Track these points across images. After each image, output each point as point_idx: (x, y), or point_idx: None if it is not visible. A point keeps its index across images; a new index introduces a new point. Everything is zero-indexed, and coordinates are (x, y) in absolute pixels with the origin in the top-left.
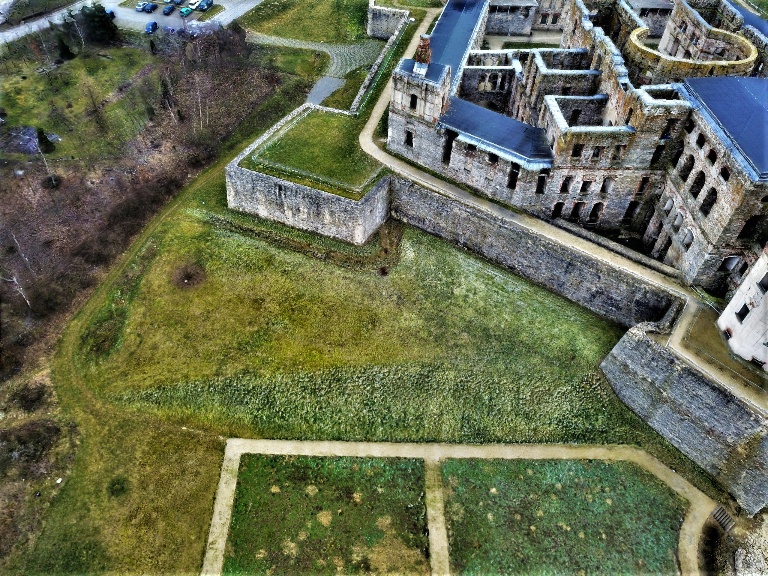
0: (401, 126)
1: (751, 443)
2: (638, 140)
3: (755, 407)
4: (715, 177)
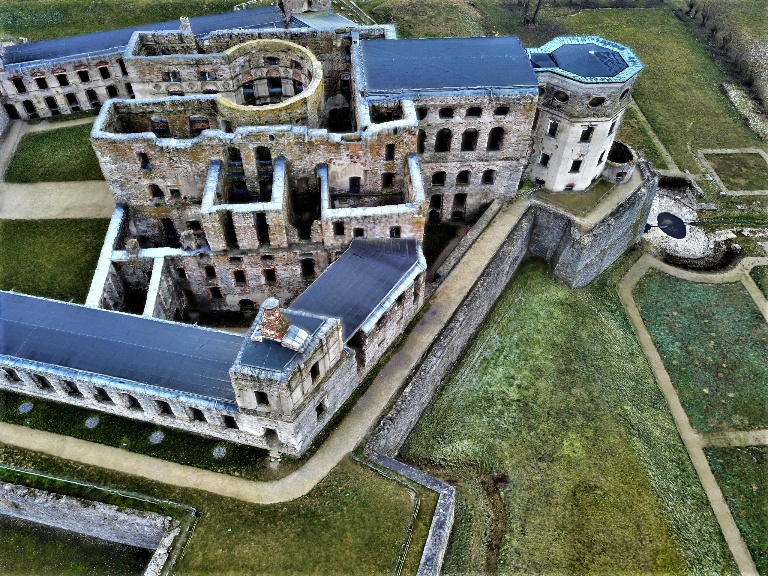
0: (311, 413)
1: None
2: None
3: (633, 193)
4: (491, 121)
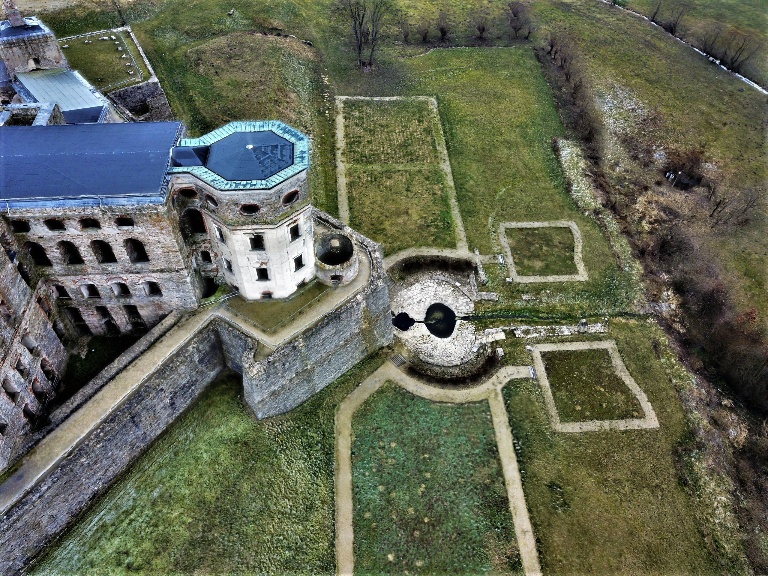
0: None
1: (365, 316)
2: (3, 285)
3: (344, 301)
4: (117, 232)
